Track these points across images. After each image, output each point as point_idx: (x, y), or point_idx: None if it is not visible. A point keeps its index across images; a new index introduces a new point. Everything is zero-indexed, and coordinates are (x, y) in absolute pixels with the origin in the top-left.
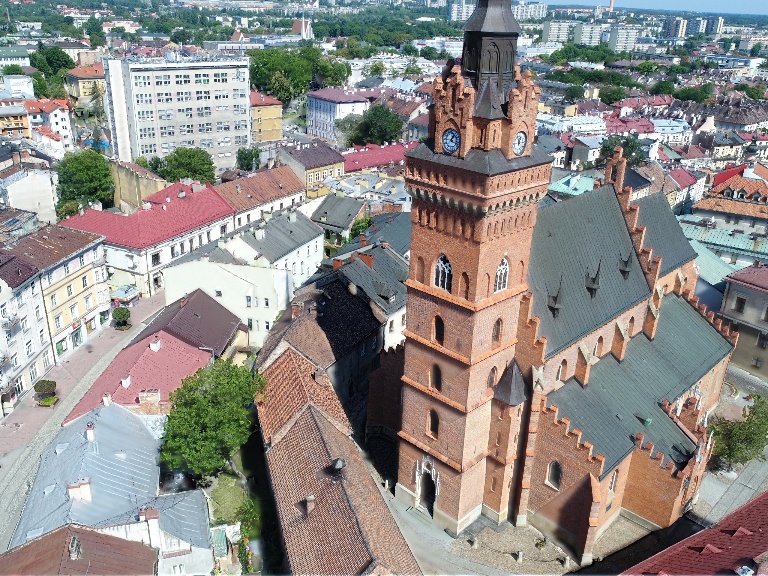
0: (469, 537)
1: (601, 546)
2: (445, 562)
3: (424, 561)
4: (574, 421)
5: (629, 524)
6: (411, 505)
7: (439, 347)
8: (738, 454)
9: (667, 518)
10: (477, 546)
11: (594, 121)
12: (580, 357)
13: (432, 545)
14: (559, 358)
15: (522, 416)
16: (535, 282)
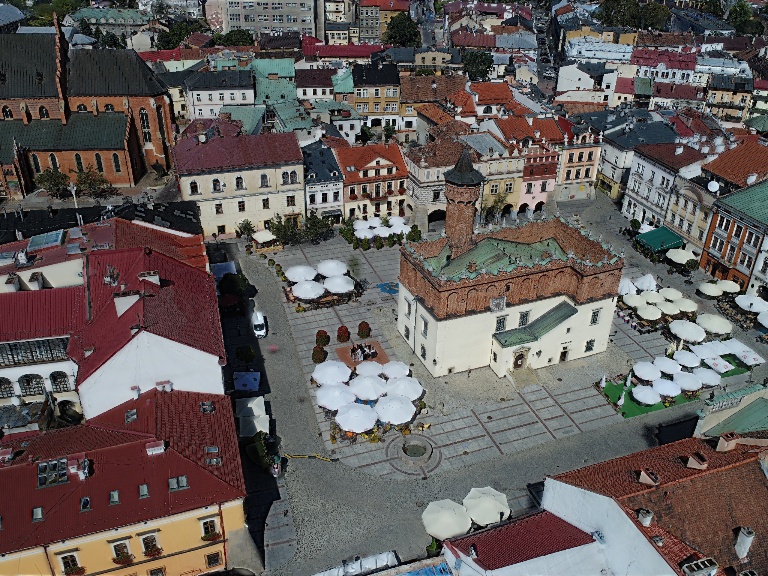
0: None
1: None
2: None
3: None
4: None
5: None
6: None
7: None
8: (35, 180)
9: None
10: None
11: (619, 50)
12: None
13: None
14: None
15: None
16: None
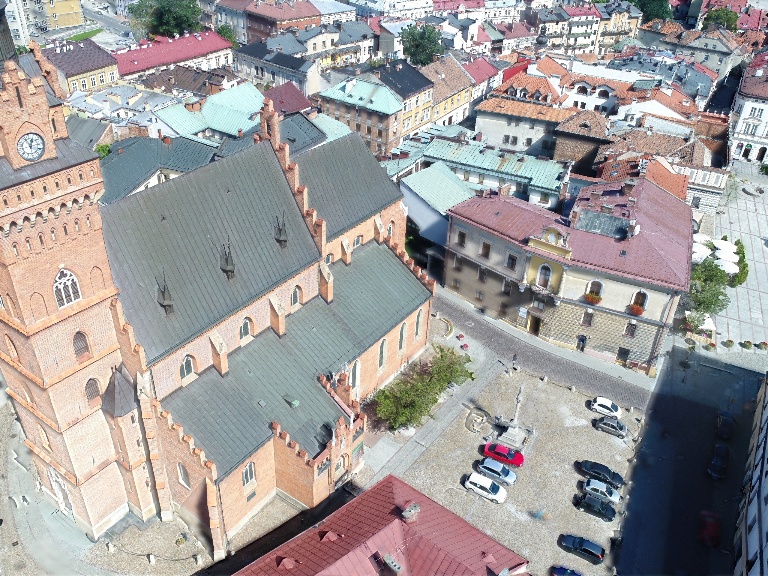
0: (109, 540)
1: (244, 534)
2: (73, 573)
3: (51, 575)
4: (200, 419)
5: (282, 504)
6: (57, 508)
7: (18, 366)
8: (400, 420)
9: (311, 500)
10: (113, 550)
11: None
12: (213, 347)
13: (66, 554)
14: (177, 356)
15: (140, 421)
16: (138, 278)
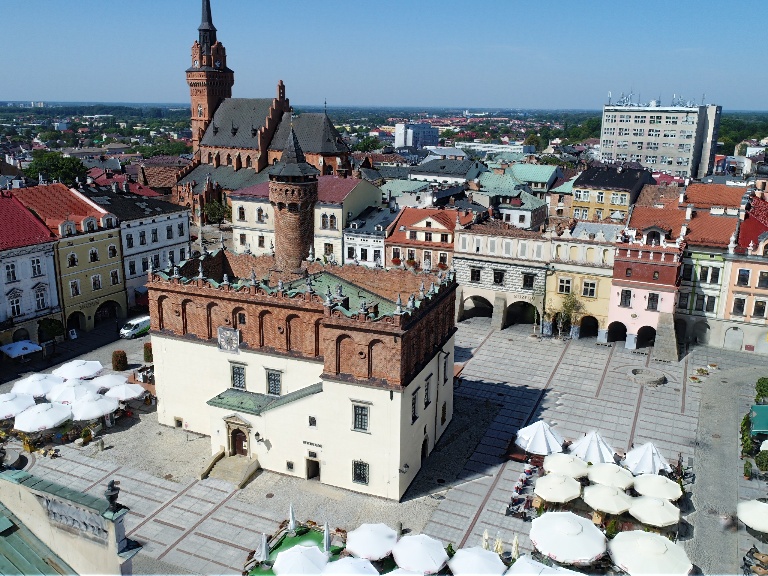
0: None
1: None
2: None
3: None
4: None
5: None
6: None
7: None
8: None
9: None
10: None
11: None
12: None
13: None
14: None
15: None
16: None
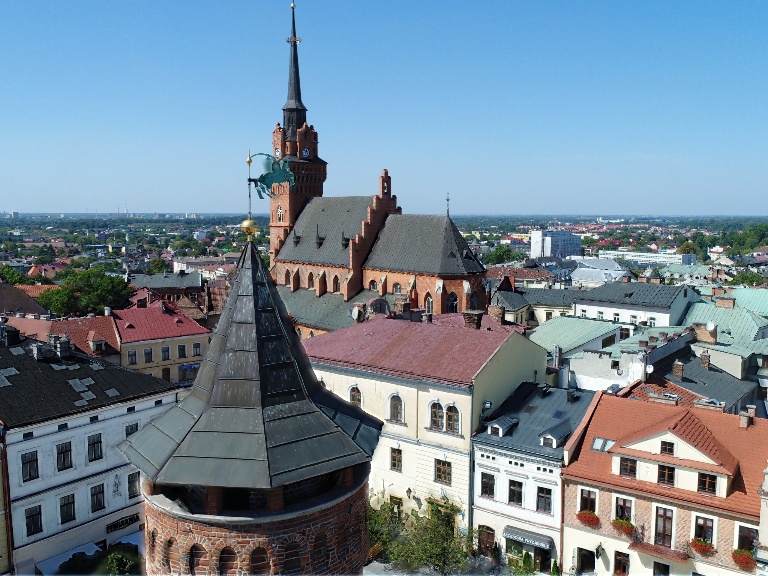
0: None
1: None
2: None
3: None
4: None
5: None
6: None
7: None
8: None
9: None
10: None
11: None
12: None
13: None
14: None
15: None
16: None
